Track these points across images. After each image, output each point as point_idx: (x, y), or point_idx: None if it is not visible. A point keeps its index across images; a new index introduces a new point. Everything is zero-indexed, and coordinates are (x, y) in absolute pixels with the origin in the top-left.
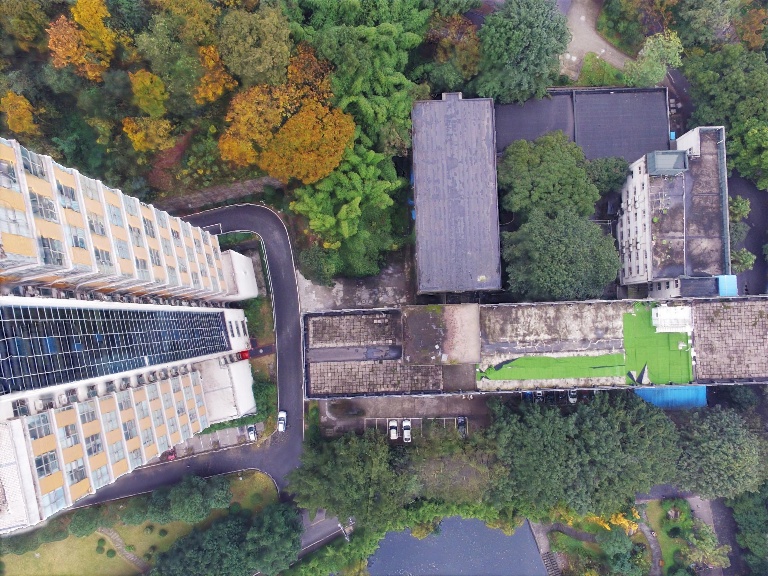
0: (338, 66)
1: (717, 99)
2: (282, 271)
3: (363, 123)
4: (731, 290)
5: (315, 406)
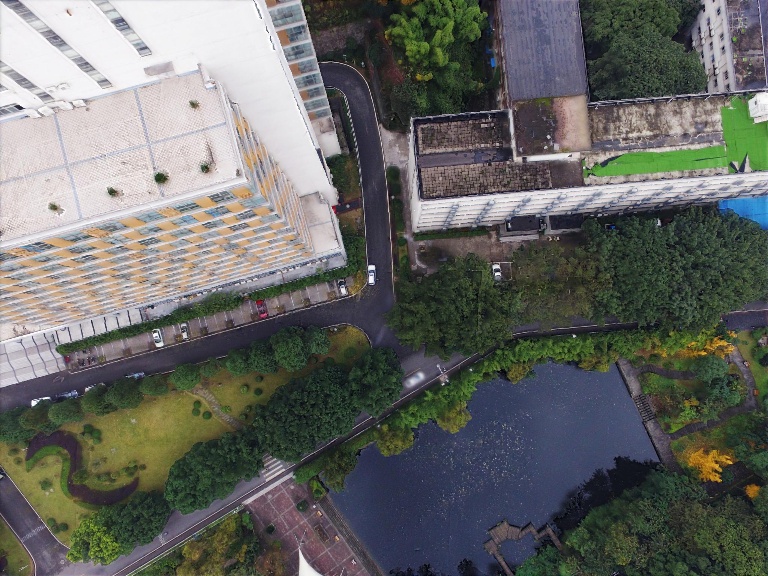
0: None
1: None
2: (365, 126)
3: None
4: None
5: (405, 255)
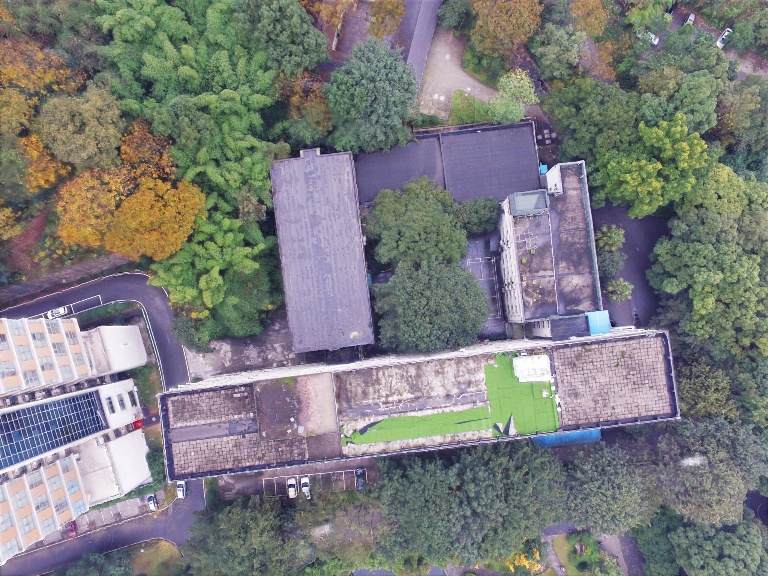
0: (176, 140)
1: (578, 133)
2: (167, 337)
3: (220, 189)
4: (603, 326)
5: None
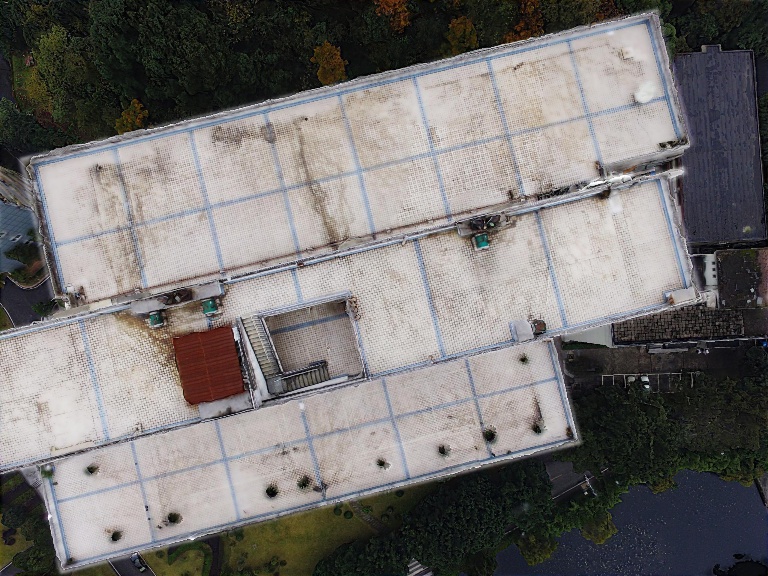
0: None
1: None
2: None
3: None
4: None
5: None
